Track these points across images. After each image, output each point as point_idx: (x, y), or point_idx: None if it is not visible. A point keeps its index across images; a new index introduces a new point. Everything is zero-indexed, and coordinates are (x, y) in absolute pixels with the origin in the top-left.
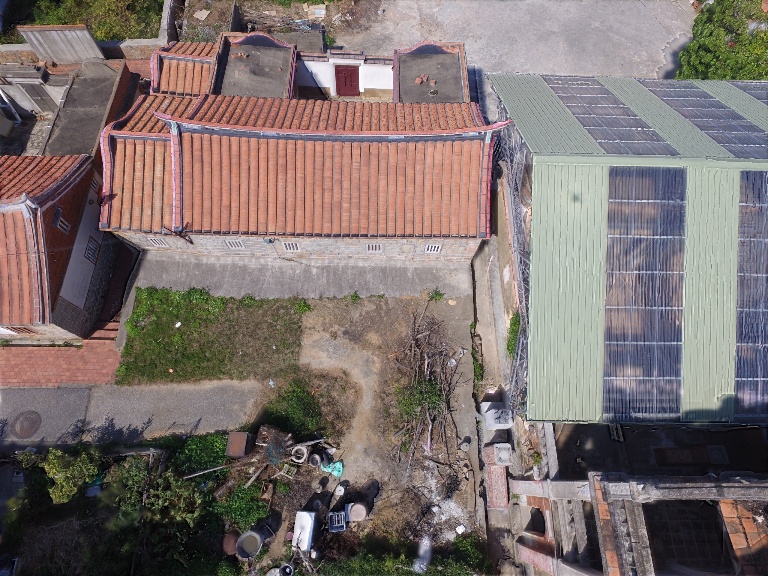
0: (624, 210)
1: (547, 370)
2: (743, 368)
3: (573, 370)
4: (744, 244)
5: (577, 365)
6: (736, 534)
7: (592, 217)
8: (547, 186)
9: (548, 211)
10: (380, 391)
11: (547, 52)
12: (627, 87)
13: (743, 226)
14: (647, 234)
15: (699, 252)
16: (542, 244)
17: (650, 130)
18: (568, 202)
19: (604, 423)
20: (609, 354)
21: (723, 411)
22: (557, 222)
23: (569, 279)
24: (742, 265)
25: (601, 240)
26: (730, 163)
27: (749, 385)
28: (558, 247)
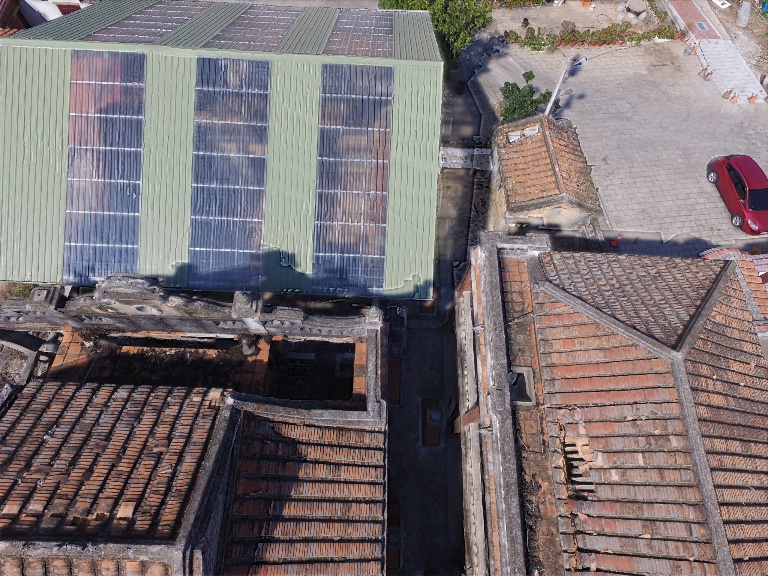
0: (85, 90)
1: (11, 235)
2: (197, 239)
3: (36, 235)
4: (200, 125)
5: (40, 231)
6: (60, 355)
7: (55, 96)
8: (12, 66)
9: (14, 90)
10: (6, 291)
11: (301, 5)
12: (229, 8)
13: (198, 109)
14: (107, 113)
15: (156, 131)
16: (8, 120)
17: (168, 31)
18: (33, 82)
19: (62, 284)
20: (70, 222)
21: (177, 278)
22: (22, 100)
23: (33, 152)
24: (197, 144)
25: (64, 117)
26: (184, 50)
27: (202, 255)
28: (23, 123)
